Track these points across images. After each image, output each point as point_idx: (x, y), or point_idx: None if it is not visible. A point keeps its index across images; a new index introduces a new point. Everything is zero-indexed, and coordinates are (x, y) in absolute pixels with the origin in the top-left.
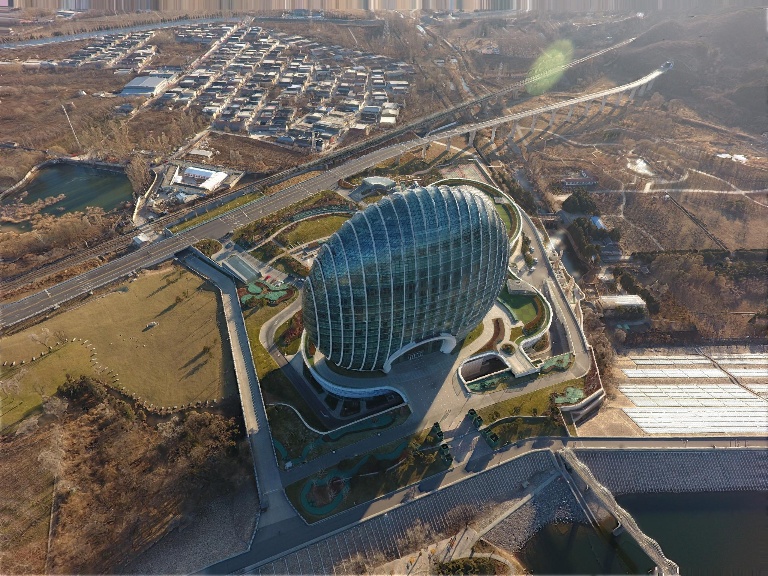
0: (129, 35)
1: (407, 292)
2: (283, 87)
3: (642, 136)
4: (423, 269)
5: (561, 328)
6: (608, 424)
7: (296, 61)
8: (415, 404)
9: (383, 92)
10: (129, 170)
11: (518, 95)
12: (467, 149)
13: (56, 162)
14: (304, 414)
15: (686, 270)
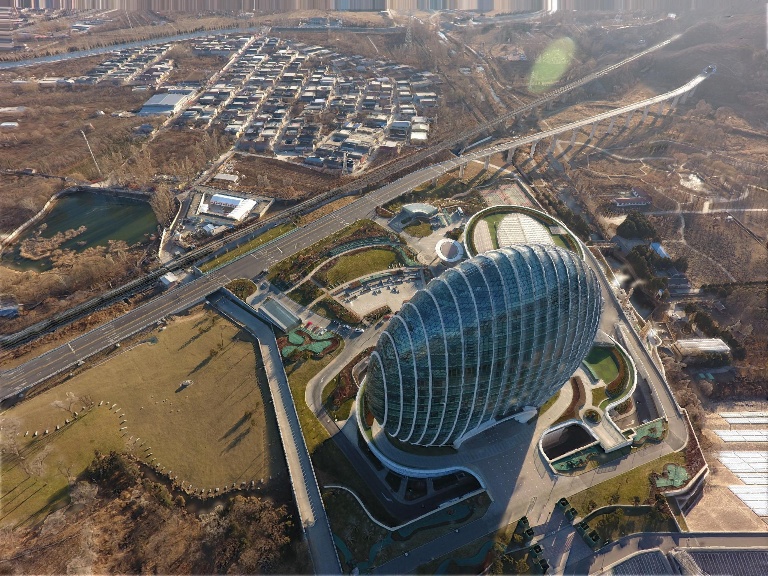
0: (145, 49)
1: (494, 370)
2: (306, 102)
3: (692, 149)
4: (515, 345)
5: (644, 384)
6: (719, 511)
7: (317, 73)
8: (494, 490)
9: (411, 105)
10: (154, 201)
11: (552, 105)
12: (506, 167)
13: (76, 190)
14: (364, 498)
15: (767, 306)
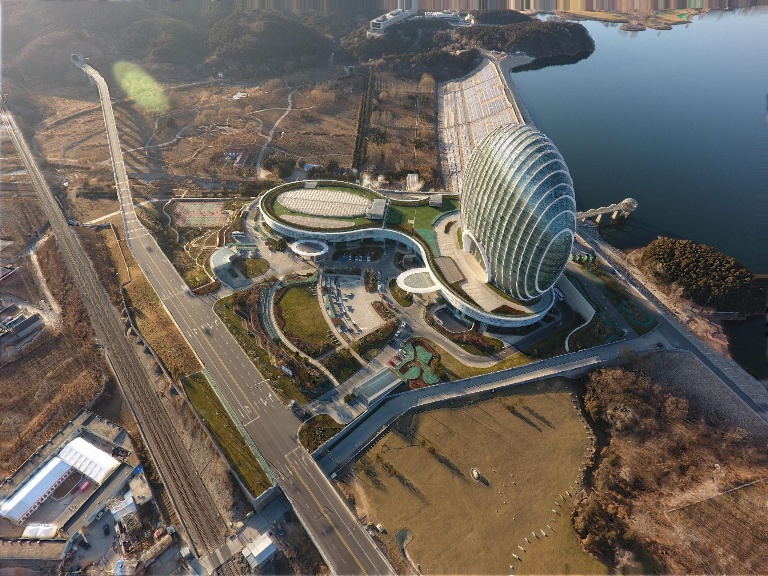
0: None
1: None
2: None
3: None
4: None
5: None
6: None
7: None
8: None
9: None
10: None
11: None
12: (136, 201)
13: None
14: None
15: None
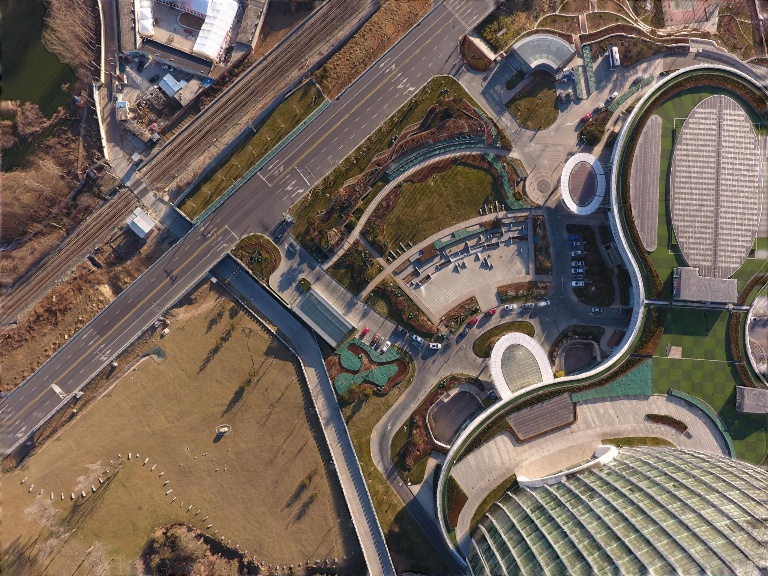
0: None
1: None
2: None
3: None
4: None
5: None
6: None
7: None
8: None
9: None
10: (52, 42)
11: None
12: None
13: None
14: None
15: None
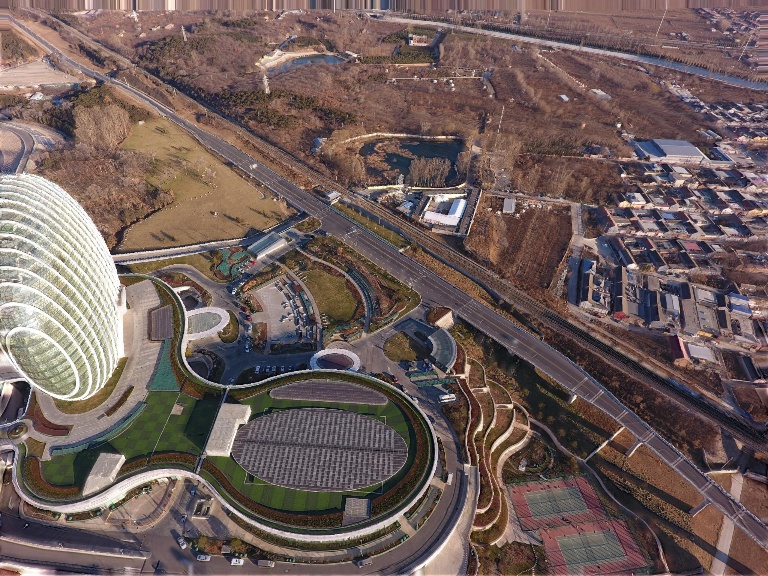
0: None
1: None
2: None
3: None
4: None
5: None
6: None
7: None
8: None
9: None
10: (415, 162)
11: None
12: (738, 568)
13: None
14: None
15: None
